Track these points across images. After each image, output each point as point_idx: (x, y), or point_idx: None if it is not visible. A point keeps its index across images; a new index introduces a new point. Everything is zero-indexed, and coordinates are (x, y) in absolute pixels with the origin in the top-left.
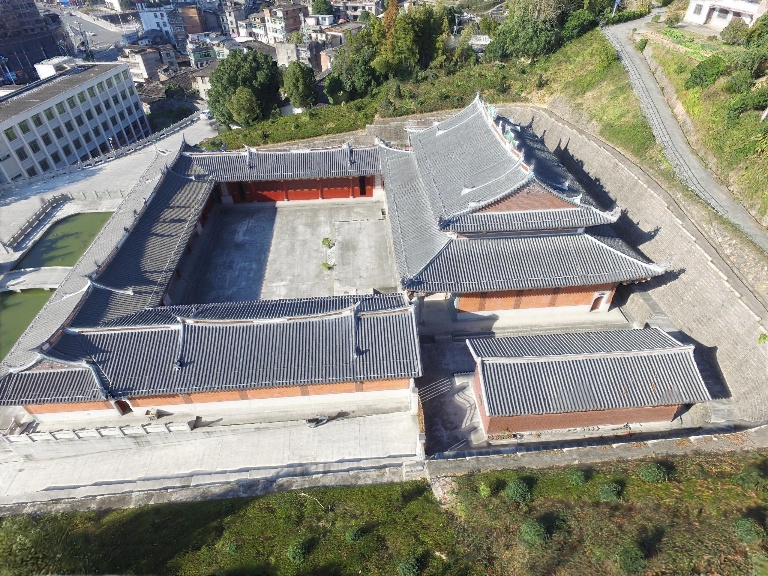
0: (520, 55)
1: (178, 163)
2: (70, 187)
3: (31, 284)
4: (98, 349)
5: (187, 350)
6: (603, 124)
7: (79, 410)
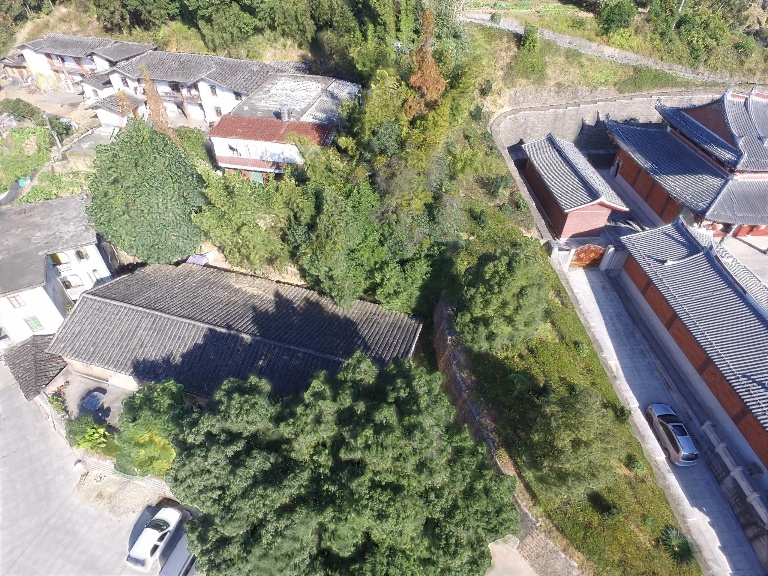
0: None
1: None
2: None
3: None
4: None
5: None
6: (613, 85)
7: None
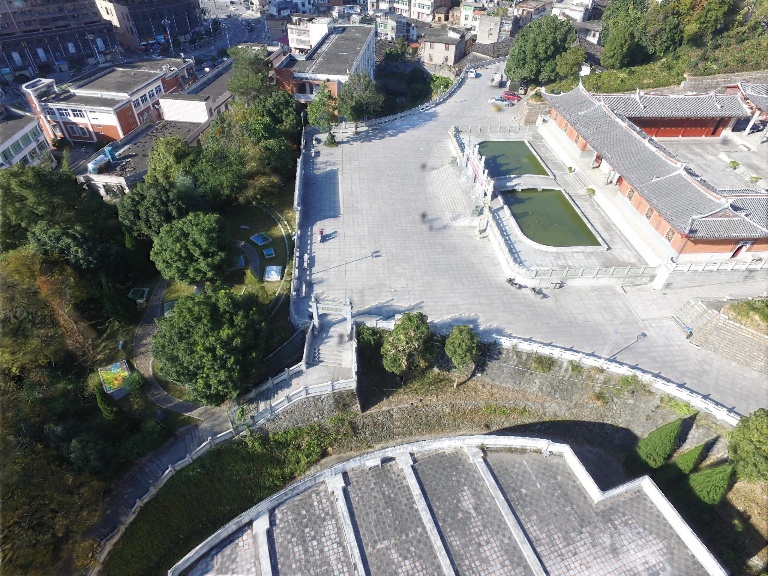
0: None
1: None
2: (429, 125)
3: (531, 185)
4: (738, 207)
5: None
6: None
7: (711, 252)
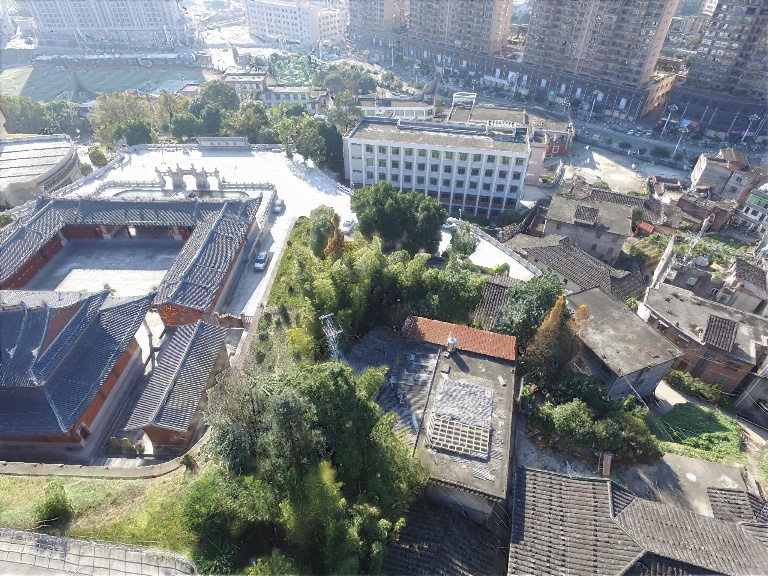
0: None
1: (213, 204)
2: (310, 189)
3: None
4: None
5: None
6: None
7: None
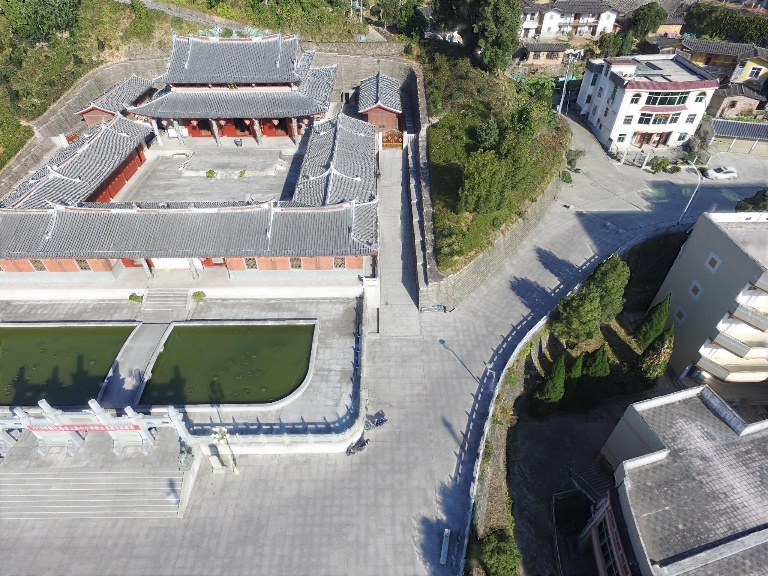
0: (54, 31)
1: None
2: None
3: (152, 356)
4: None
5: (348, 175)
6: None
7: None
